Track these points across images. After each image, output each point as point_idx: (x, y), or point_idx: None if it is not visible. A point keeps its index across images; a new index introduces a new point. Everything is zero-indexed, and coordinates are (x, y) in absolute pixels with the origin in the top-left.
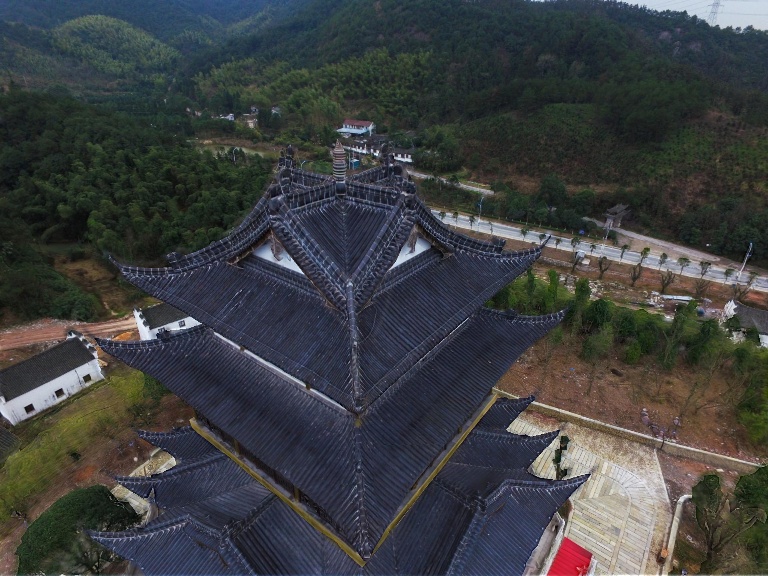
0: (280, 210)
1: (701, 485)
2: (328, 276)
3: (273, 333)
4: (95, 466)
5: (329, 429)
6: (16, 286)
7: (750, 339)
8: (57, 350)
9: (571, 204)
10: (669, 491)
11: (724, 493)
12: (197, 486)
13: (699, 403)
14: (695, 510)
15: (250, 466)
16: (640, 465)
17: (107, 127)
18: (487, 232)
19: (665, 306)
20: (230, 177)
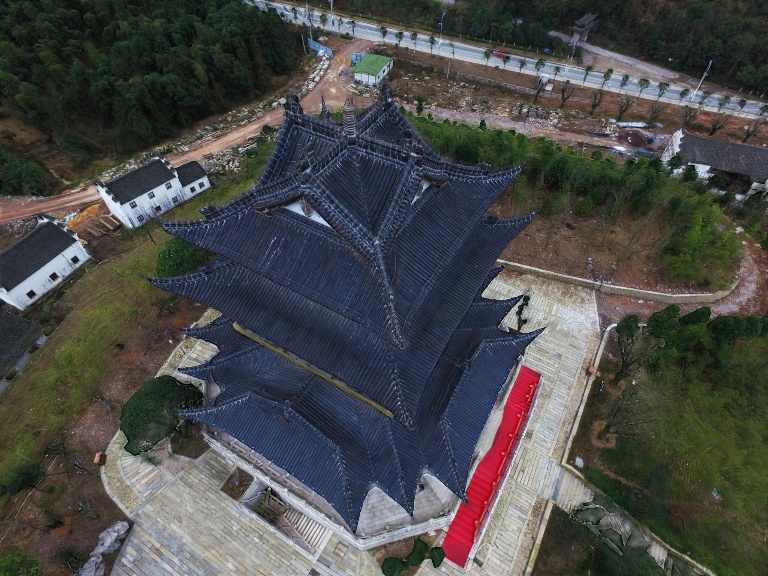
0: (310, 181)
1: (624, 322)
2: (357, 234)
3: (315, 279)
4: (137, 350)
5: (365, 341)
6: None
7: (687, 176)
8: (35, 236)
9: (538, 16)
10: (601, 322)
11: (640, 319)
12: (245, 368)
13: (634, 249)
14: (617, 335)
15: (295, 358)
16: (581, 304)
17: None
18: (448, 55)
19: (619, 135)
20: None
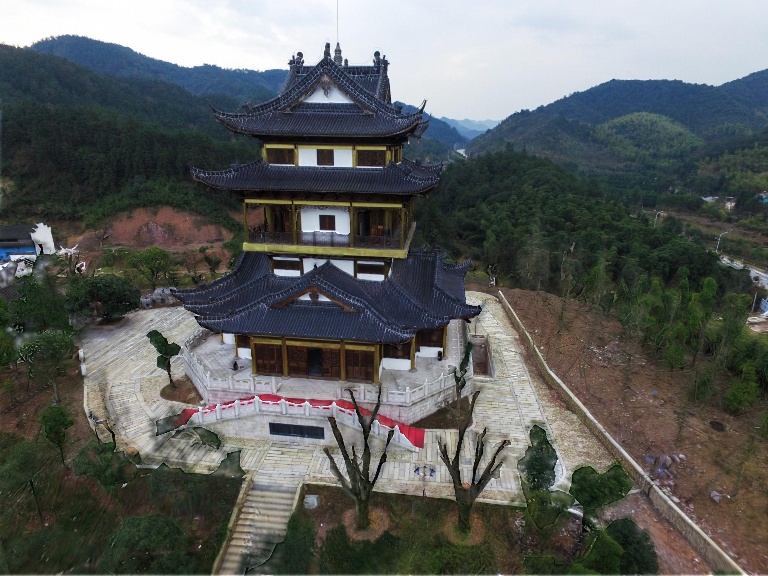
0: None
1: None
2: None
3: None
4: None
5: None
6: (414, 247)
7: None
8: None
9: None
10: (580, 506)
11: None
12: None
13: None
14: (578, 532)
15: None
16: None
17: (551, 177)
18: None
19: None
20: (617, 225)
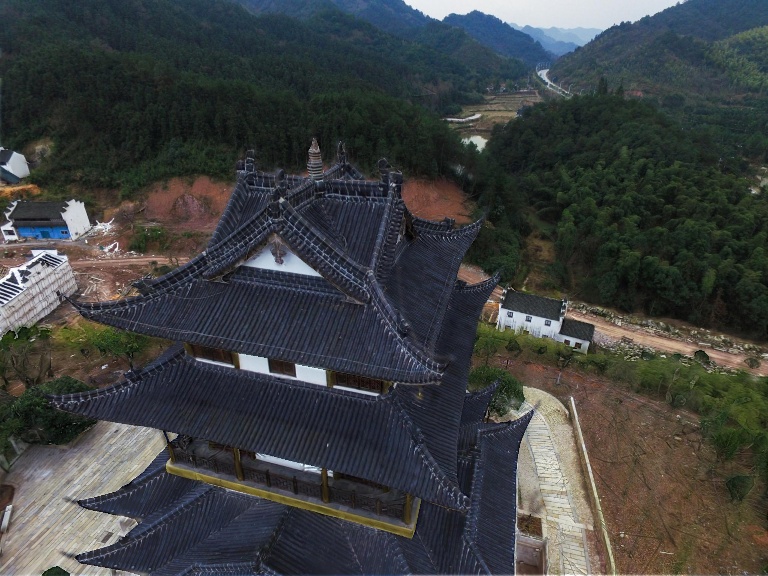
0: None
1: None
2: None
3: None
4: None
5: None
6: None
7: None
8: None
9: None
10: None
11: None
12: None
13: None
14: None
15: None
16: None
17: (653, 135)
18: None
19: None
20: (735, 215)
